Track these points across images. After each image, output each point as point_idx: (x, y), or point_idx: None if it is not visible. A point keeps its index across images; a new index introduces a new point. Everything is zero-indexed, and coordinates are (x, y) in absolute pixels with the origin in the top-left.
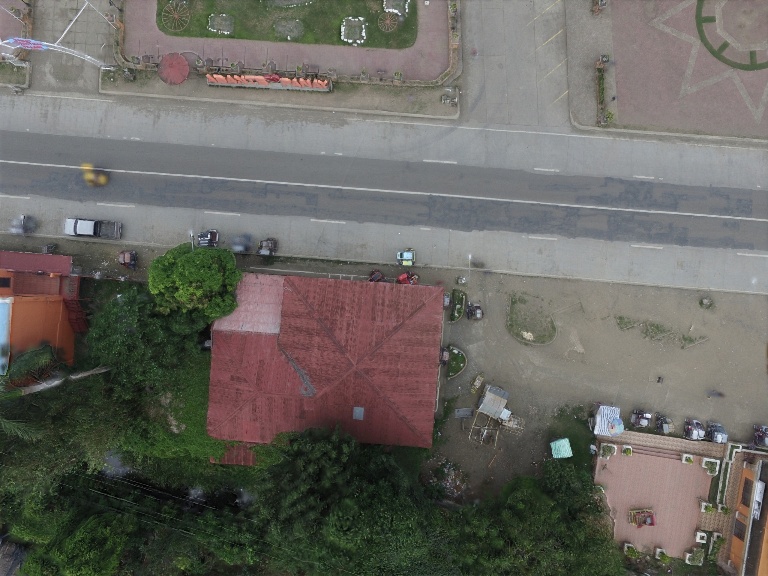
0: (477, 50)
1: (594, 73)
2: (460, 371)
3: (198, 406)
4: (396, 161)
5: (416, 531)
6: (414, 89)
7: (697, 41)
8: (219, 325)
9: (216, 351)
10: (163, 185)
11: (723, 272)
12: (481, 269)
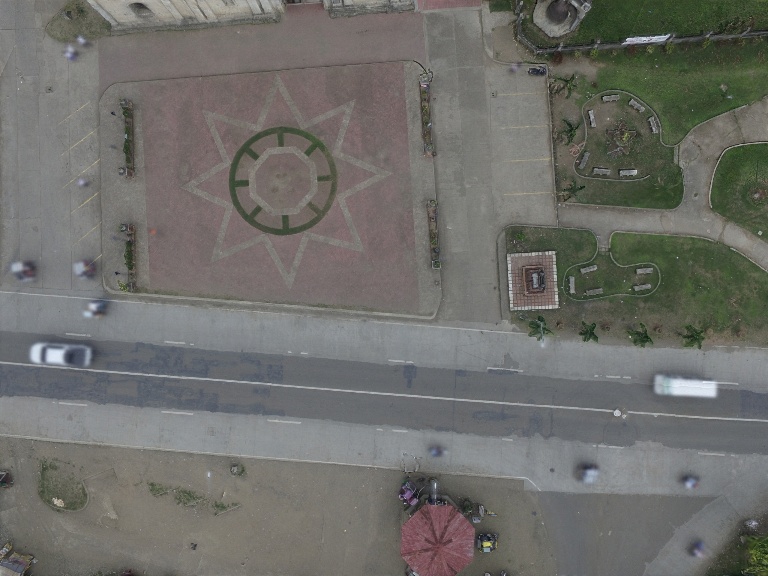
0: (12, 213)
1: (126, 237)
2: None
3: None
4: None
5: None
6: None
7: (230, 205)
8: None
9: None
10: None
11: (254, 438)
12: (11, 435)
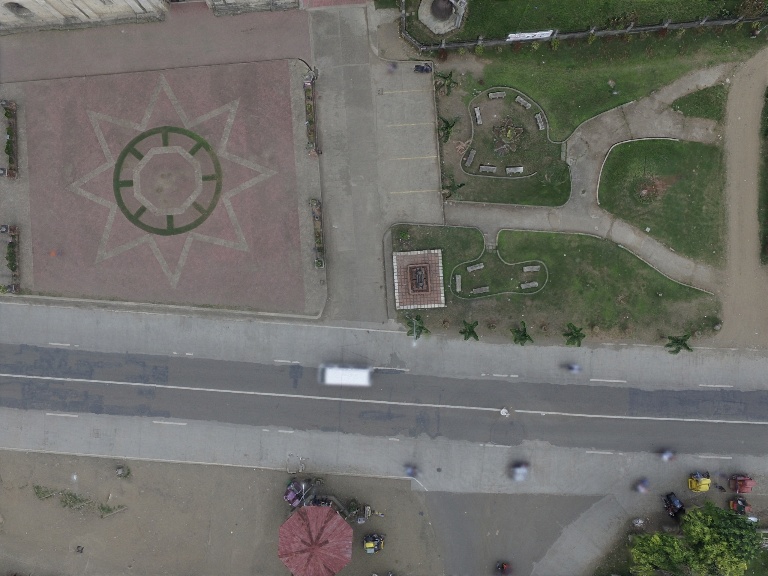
0: None
1: (10, 239)
2: None
3: None
4: None
5: None
6: None
7: (114, 206)
8: None
9: None
10: None
11: (139, 440)
12: None
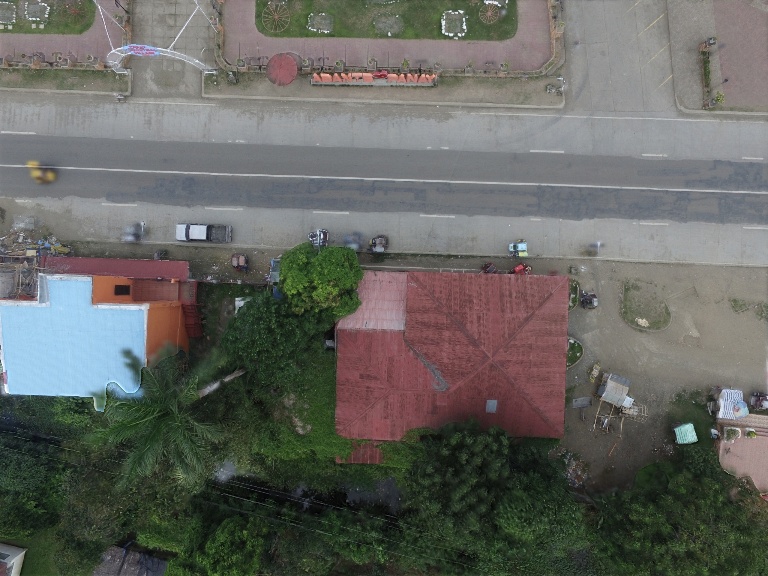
0: (579, 38)
1: (698, 56)
2: (577, 361)
3: (323, 406)
4: (503, 153)
5: (579, 521)
6: (518, 80)
7: None
8: (343, 324)
9: (342, 350)
10: (270, 187)
11: None
12: (593, 257)
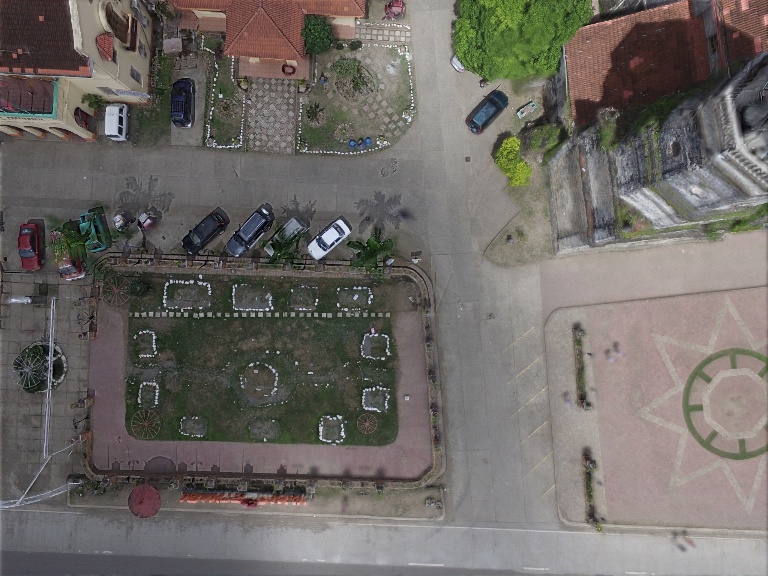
0: (460, 445)
1: (581, 467)
2: None
3: None
4: (381, 566)
5: None
6: (397, 491)
7: (685, 431)
8: None
9: None
10: None
11: None
12: None
